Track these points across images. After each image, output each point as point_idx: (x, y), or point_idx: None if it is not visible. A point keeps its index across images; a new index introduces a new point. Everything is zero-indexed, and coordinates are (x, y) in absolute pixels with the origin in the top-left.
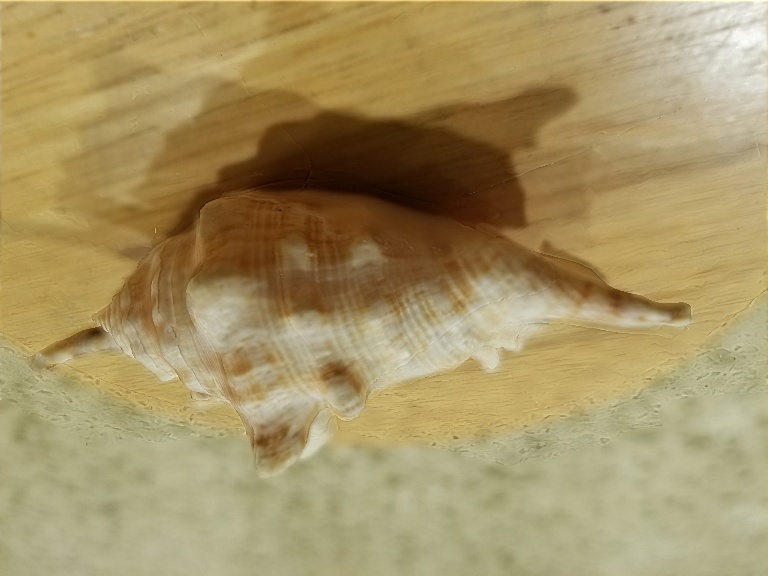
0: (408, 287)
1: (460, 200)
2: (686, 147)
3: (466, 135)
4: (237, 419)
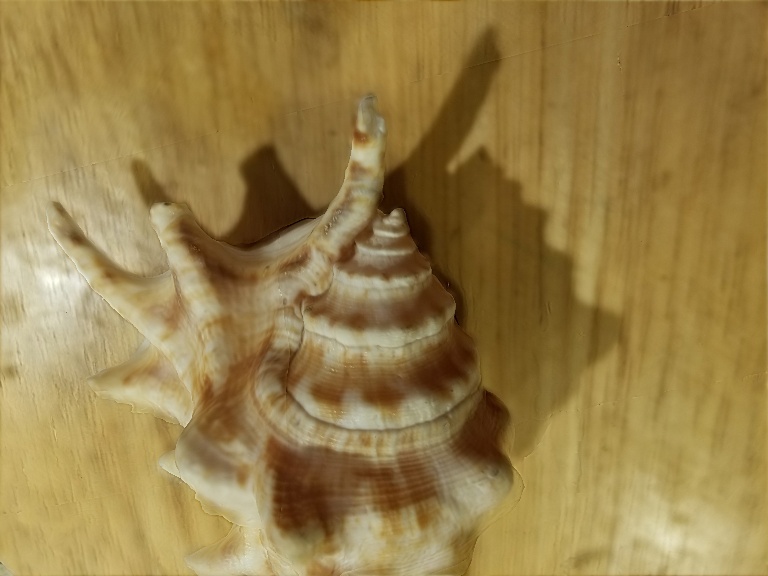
0: None
1: None
2: None
3: None
4: None
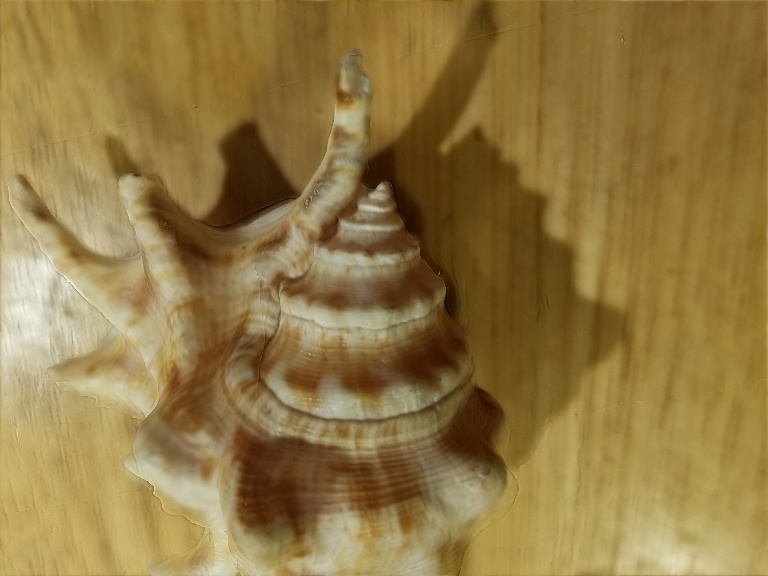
0: None
1: None
2: None
3: None
4: None
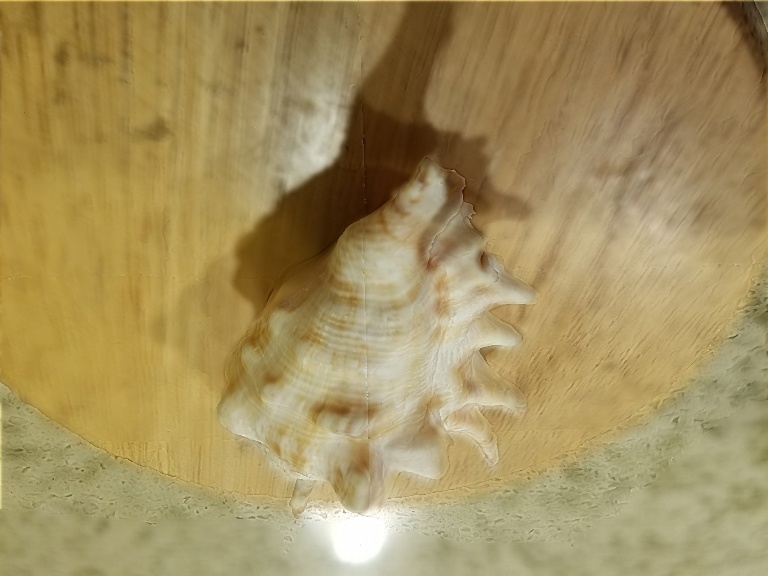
0: (313, 319)
1: (367, 212)
2: (408, 24)
3: (299, 182)
4: (646, 455)
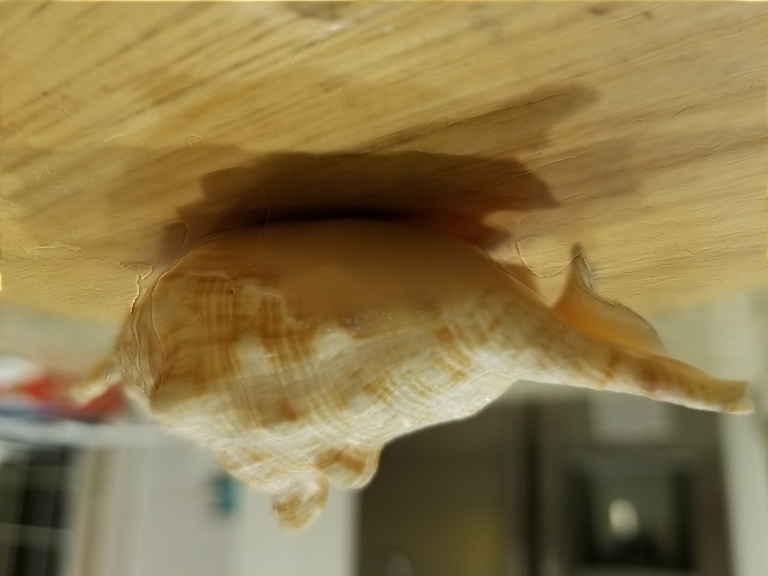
0: (391, 370)
1: (464, 197)
2: None
3: (443, 151)
4: None
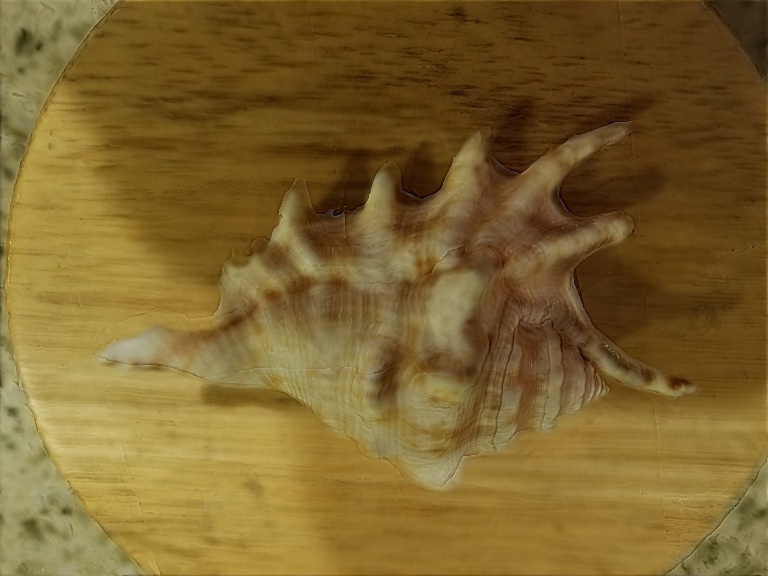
0: None
1: None
2: None
3: None
4: None
